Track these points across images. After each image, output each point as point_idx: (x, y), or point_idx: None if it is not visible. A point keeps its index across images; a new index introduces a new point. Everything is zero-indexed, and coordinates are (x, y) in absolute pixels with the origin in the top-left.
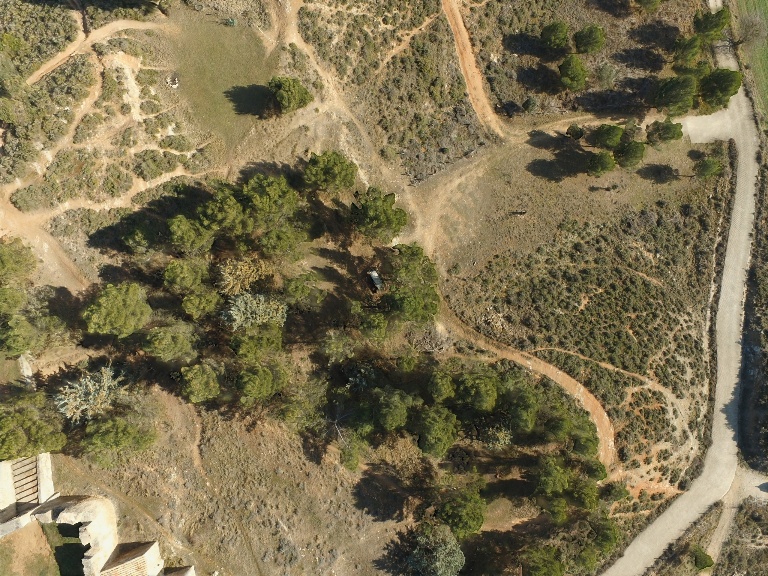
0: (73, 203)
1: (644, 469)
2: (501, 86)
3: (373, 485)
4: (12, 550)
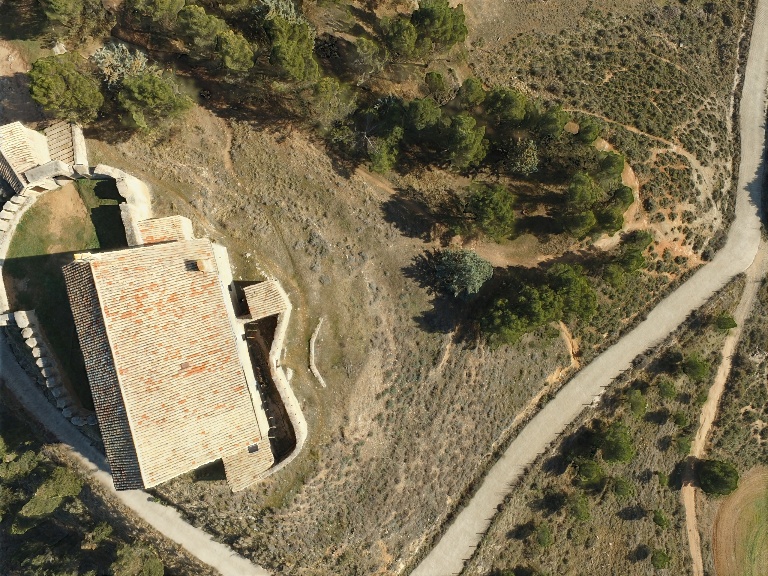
0: None
1: (668, 225)
2: None
3: (401, 208)
4: (49, 212)
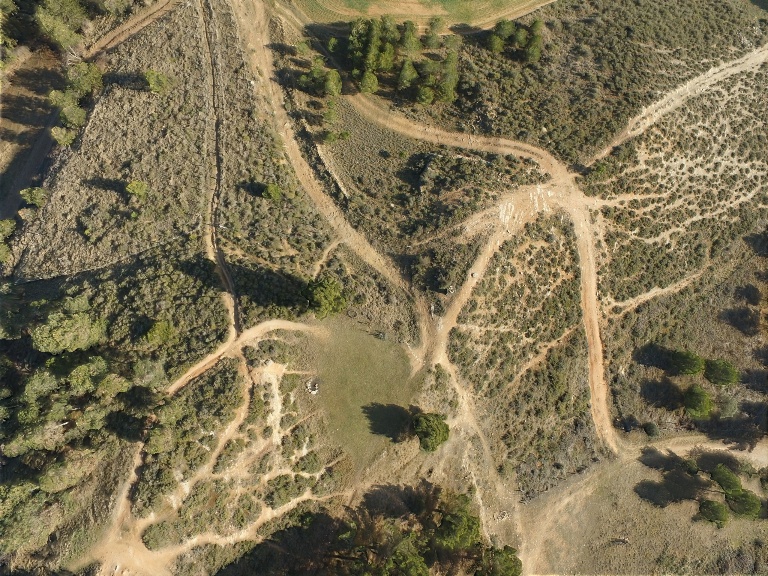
0: (201, 538)
1: None
2: (623, 398)
3: None
4: None
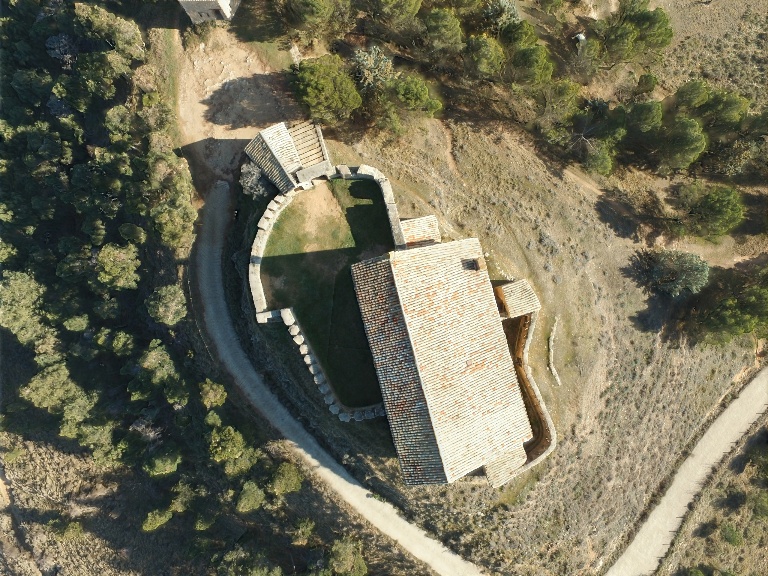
0: None
1: None
2: None
3: (609, 208)
4: (305, 211)
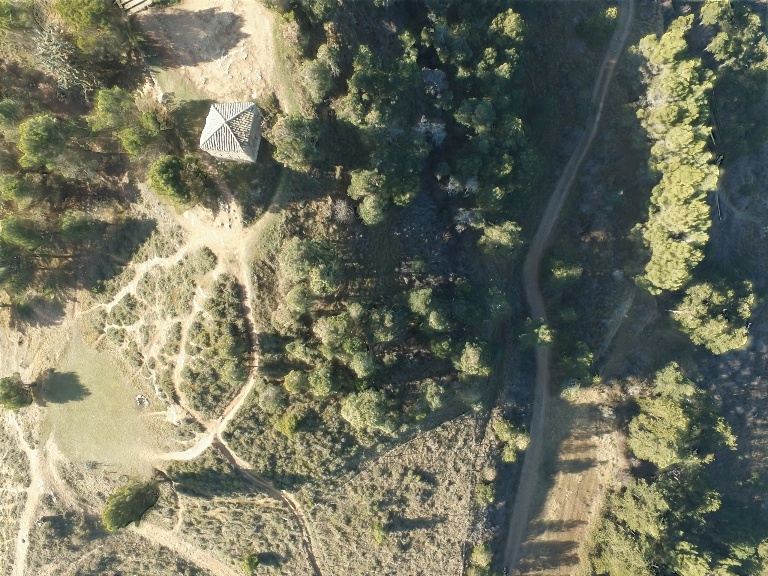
0: (174, 262)
1: None
2: None
3: None
4: None
